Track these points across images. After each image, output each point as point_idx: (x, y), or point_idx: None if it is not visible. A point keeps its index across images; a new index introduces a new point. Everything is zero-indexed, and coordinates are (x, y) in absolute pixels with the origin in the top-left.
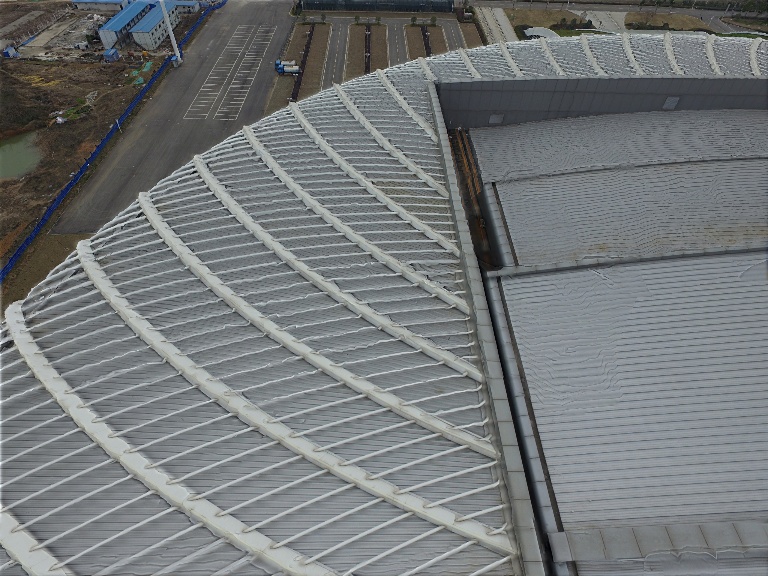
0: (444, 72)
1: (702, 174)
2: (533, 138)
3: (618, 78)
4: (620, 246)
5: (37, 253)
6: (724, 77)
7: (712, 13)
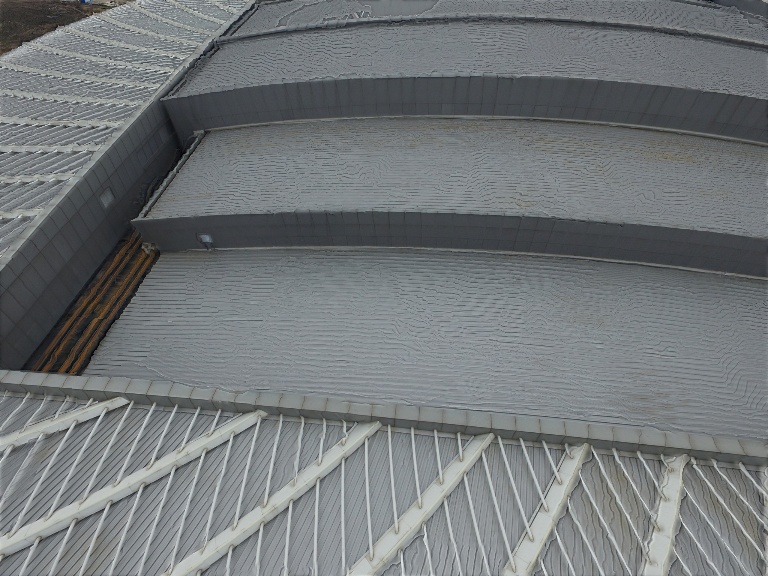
0: None
1: None
2: None
3: None
4: None
5: None
6: None
7: None
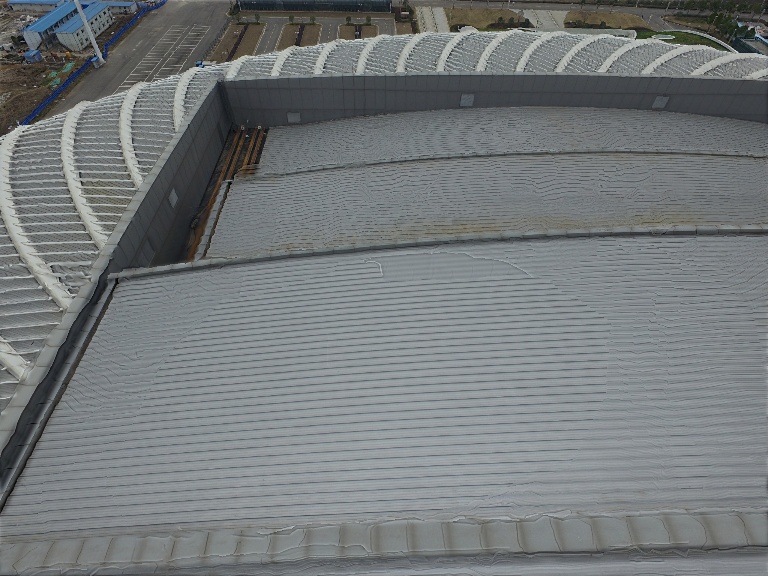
0: (249, 70)
1: (426, 172)
2: (324, 137)
3: (404, 75)
4: (305, 246)
5: None
6: (513, 74)
7: (655, 11)
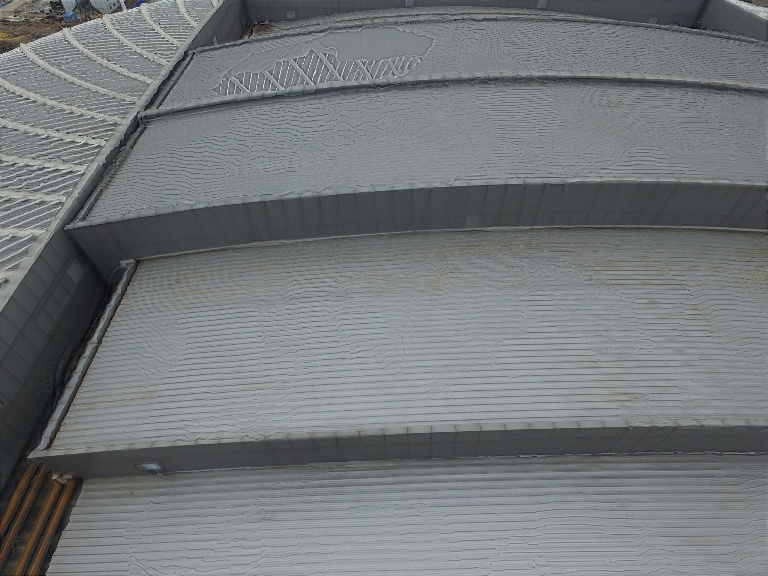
0: None
1: None
2: None
3: None
4: None
5: None
6: None
7: None
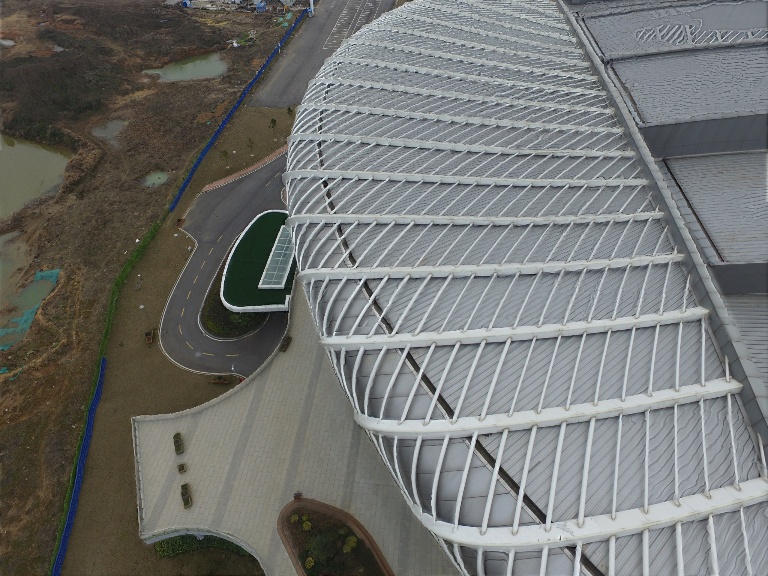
0: None
1: None
2: None
3: None
4: None
5: (241, 115)
6: None
7: None
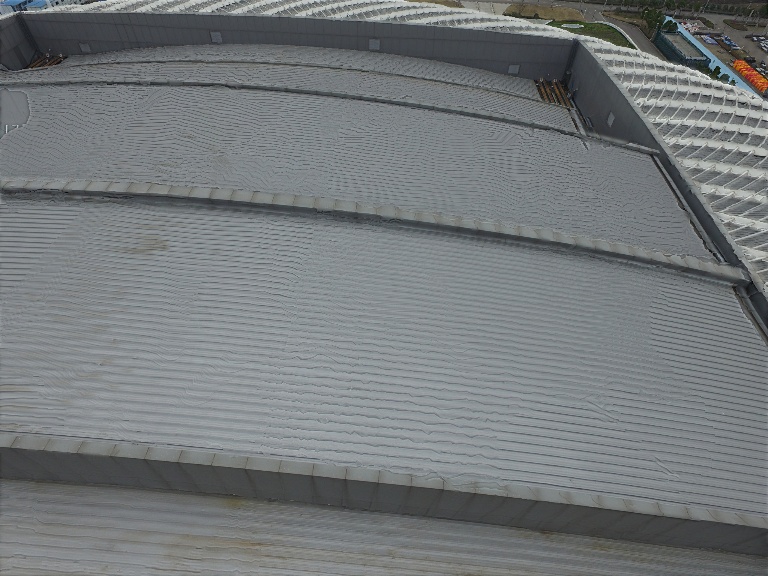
0: None
1: (106, 71)
2: None
3: (159, 13)
4: None
5: None
6: (244, 15)
7: (598, 7)
